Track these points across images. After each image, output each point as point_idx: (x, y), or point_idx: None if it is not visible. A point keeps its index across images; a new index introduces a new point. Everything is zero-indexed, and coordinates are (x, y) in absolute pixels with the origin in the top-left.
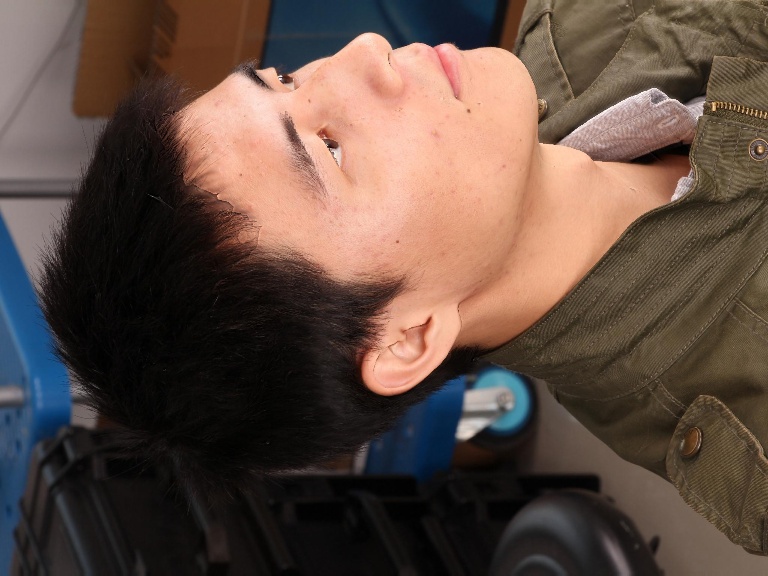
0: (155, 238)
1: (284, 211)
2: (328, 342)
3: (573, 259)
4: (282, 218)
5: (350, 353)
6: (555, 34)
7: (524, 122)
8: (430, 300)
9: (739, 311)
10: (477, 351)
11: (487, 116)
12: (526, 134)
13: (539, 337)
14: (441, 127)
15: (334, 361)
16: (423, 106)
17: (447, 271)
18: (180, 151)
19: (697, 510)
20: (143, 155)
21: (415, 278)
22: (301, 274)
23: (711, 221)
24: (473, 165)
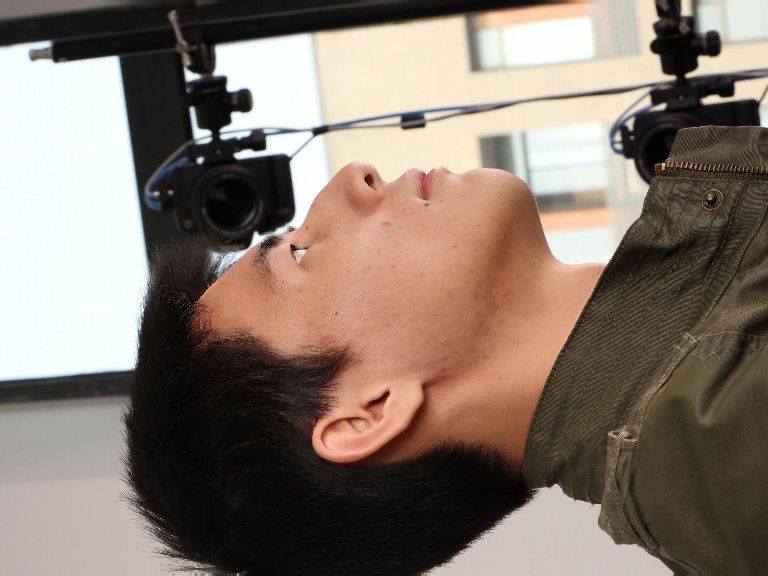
0: (144, 342)
1: (243, 301)
2: (277, 412)
3: (562, 345)
4: (240, 307)
5: (303, 424)
6: None
7: (485, 211)
8: (384, 373)
9: None
10: (500, 458)
11: (446, 208)
12: (486, 221)
13: (543, 430)
14: (396, 219)
15: (283, 429)
16: (388, 208)
17: (395, 343)
18: None
19: (601, 526)
20: (156, 284)
21: (361, 349)
22: (243, 347)
23: (669, 275)
24: (420, 246)
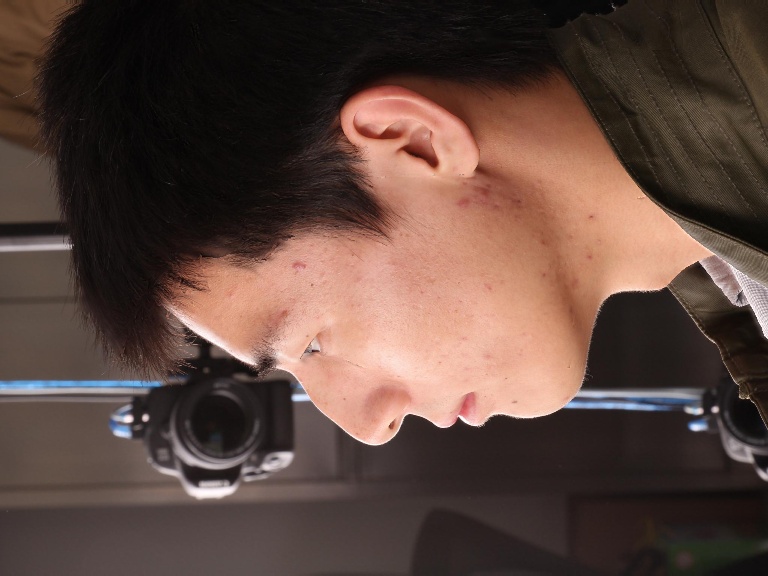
0: None
1: None
2: None
3: None
4: None
5: None
6: None
7: None
8: None
9: None
10: None
11: None
12: None
13: None
14: None
15: None
16: None
17: None
18: None
19: None
20: None
21: None
22: None
23: None
24: None
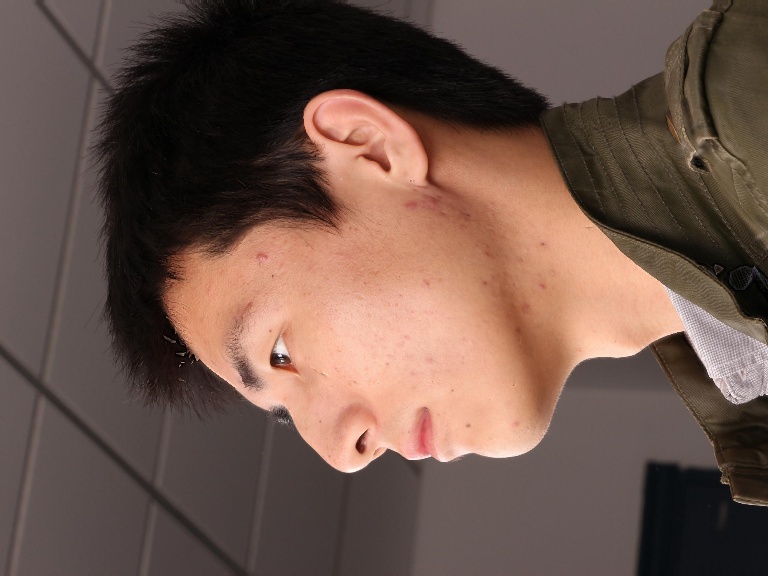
0: None
1: None
2: None
3: None
4: None
5: None
6: (696, 163)
7: None
8: None
9: None
10: None
11: None
12: None
13: None
14: None
15: None
16: None
17: None
18: None
19: None
20: None
21: None
22: None
23: None
24: None
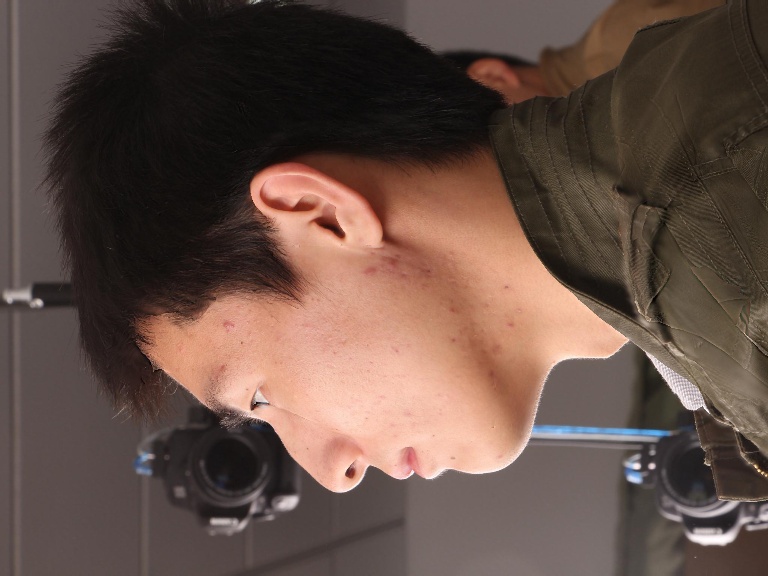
0: None
1: None
2: None
3: None
4: None
5: None
6: (653, 313)
7: None
8: None
9: (764, 278)
10: None
11: None
12: None
13: None
14: None
15: None
16: None
17: None
18: None
19: None
20: None
21: None
22: None
23: None
24: None
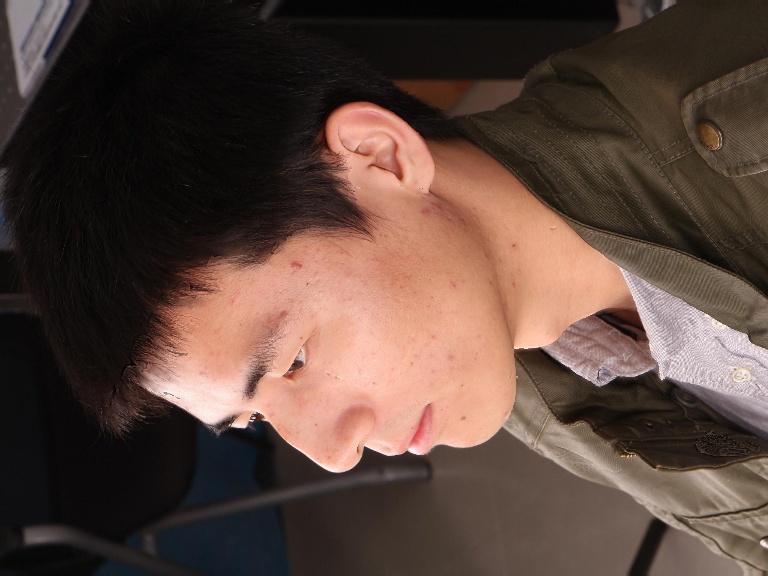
0: None
1: None
2: None
3: None
4: None
5: None
6: None
7: None
8: None
9: None
10: None
11: None
12: None
13: None
14: None
15: None
16: None
17: None
18: (142, 360)
19: None
20: None
21: None
22: None
23: None
24: None
